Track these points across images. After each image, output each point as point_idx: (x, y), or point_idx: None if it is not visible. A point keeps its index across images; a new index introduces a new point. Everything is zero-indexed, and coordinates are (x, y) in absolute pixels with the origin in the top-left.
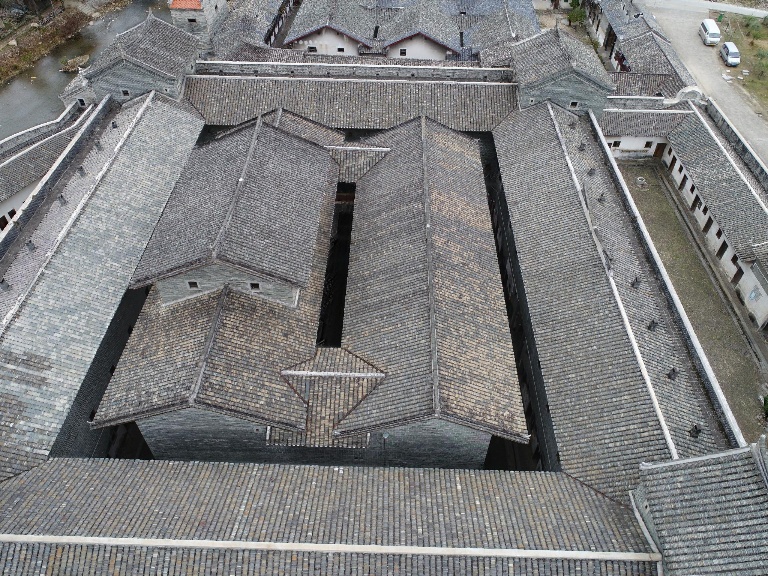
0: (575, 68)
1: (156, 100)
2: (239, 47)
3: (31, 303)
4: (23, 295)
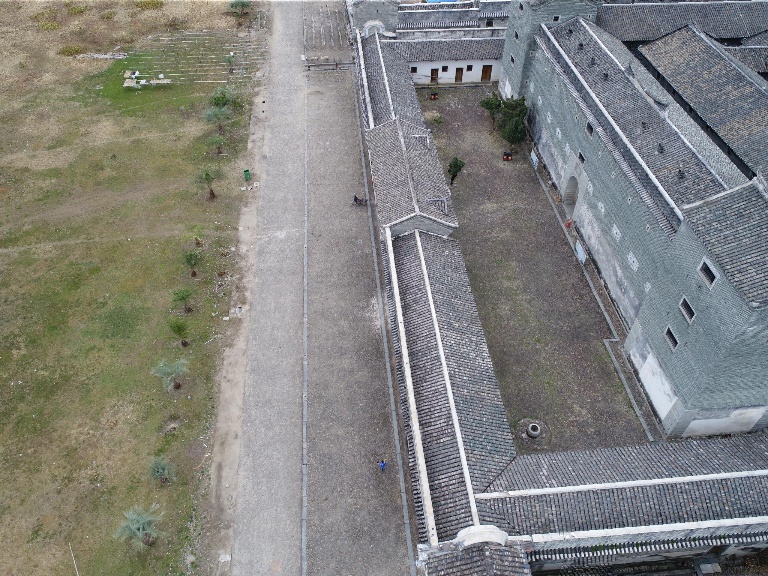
0: None
1: None
2: None
3: None
4: None
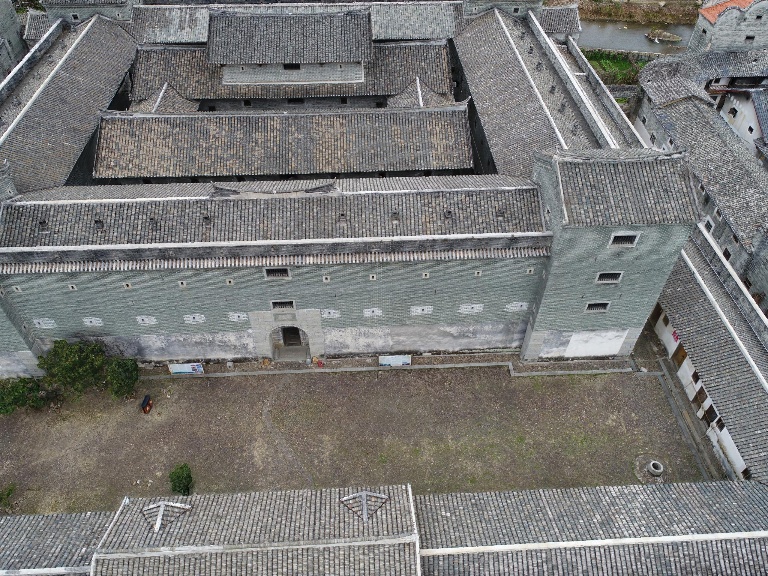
0: (553, 161)
1: (453, 6)
2: (671, 62)
3: (229, 10)
4: (231, 5)
